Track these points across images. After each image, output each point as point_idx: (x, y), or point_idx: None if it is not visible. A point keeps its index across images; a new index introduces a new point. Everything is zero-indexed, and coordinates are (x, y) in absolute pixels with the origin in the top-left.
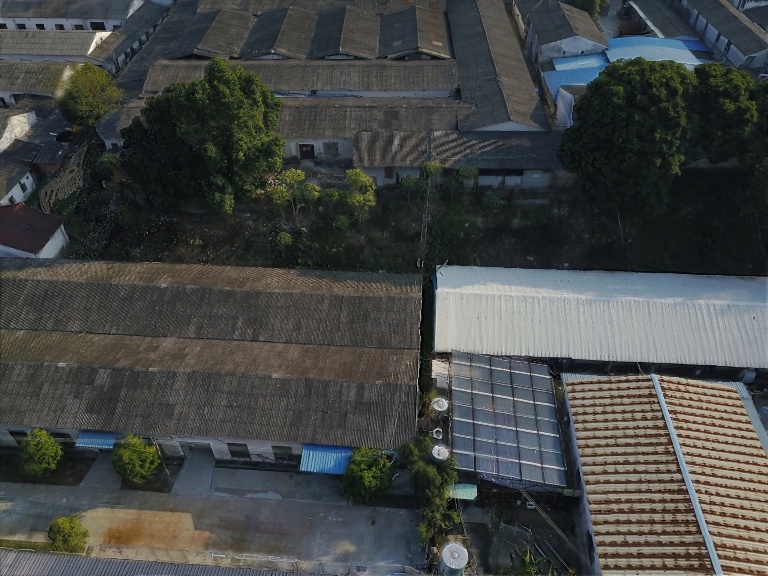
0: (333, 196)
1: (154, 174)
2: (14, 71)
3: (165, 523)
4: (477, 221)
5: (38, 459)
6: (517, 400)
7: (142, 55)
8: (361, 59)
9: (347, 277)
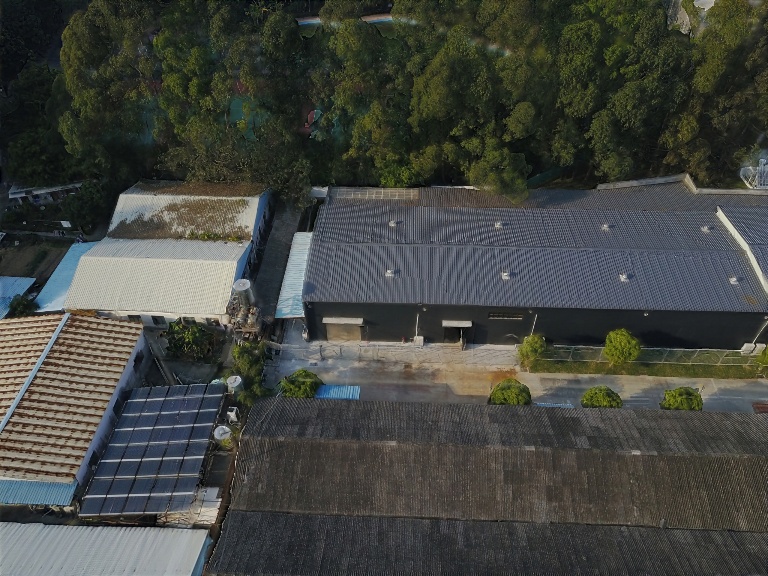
0: None
1: None
2: None
3: (473, 387)
4: None
5: None
6: (139, 459)
7: None
8: None
9: None
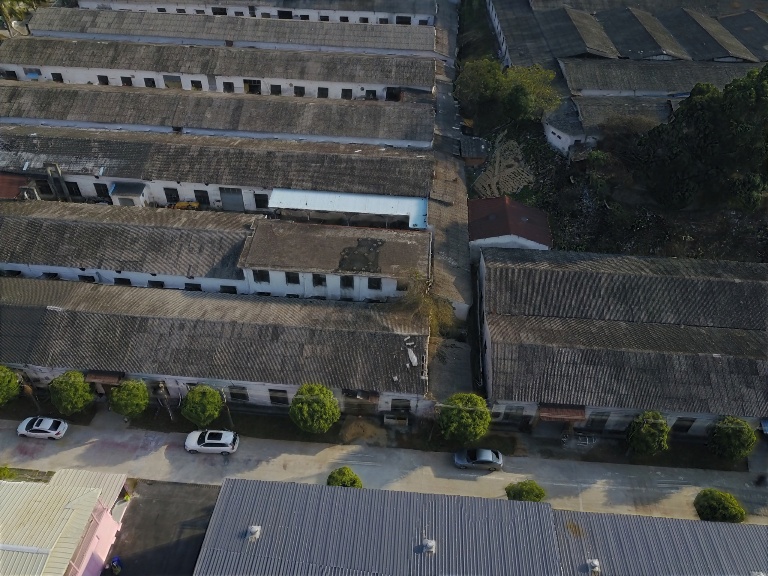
0: None
1: (694, 172)
2: (384, 64)
3: None
4: None
5: (747, 446)
6: None
7: (519, 52)
8: (750, 62)
9: None
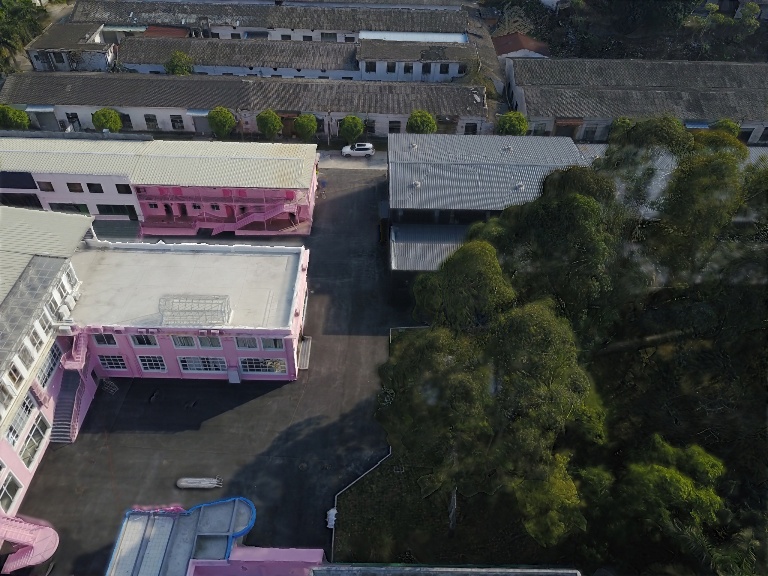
0: (732, 22)
1: (641, 1)
2: None
3: None
4: None
5: None
6: None
7: None
8: None
9: None
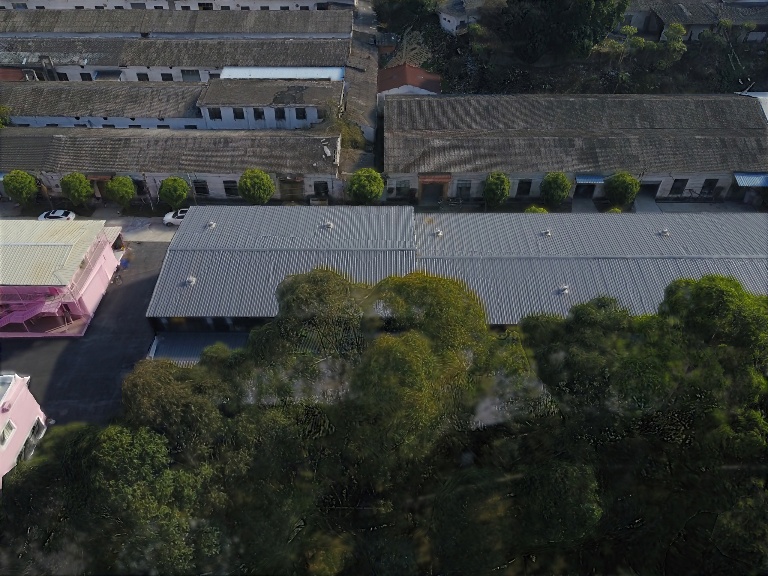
0: (654, 46)
1: (540, 27)
2: None
3: None
4: (750, 65)
5: (563, 188)
6: None
7: None
8: None
9: (688, 95)
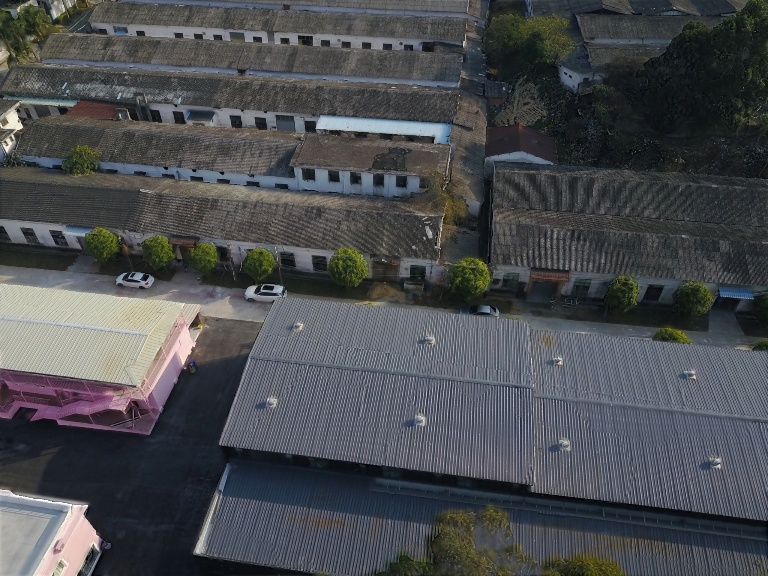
0: None
1: (682, 96)
2: (421, 22)
3: None
4: None
5: (704, 303)
6: None
7: (542, 10)
8: None
9: None
